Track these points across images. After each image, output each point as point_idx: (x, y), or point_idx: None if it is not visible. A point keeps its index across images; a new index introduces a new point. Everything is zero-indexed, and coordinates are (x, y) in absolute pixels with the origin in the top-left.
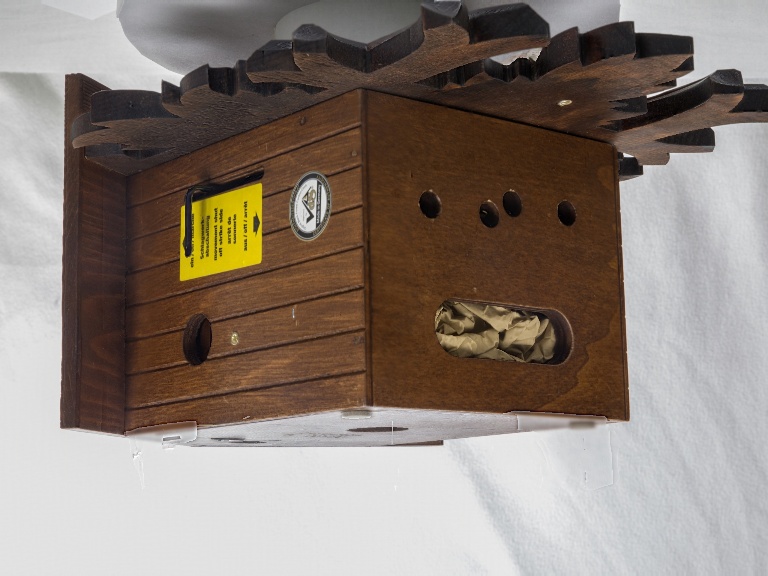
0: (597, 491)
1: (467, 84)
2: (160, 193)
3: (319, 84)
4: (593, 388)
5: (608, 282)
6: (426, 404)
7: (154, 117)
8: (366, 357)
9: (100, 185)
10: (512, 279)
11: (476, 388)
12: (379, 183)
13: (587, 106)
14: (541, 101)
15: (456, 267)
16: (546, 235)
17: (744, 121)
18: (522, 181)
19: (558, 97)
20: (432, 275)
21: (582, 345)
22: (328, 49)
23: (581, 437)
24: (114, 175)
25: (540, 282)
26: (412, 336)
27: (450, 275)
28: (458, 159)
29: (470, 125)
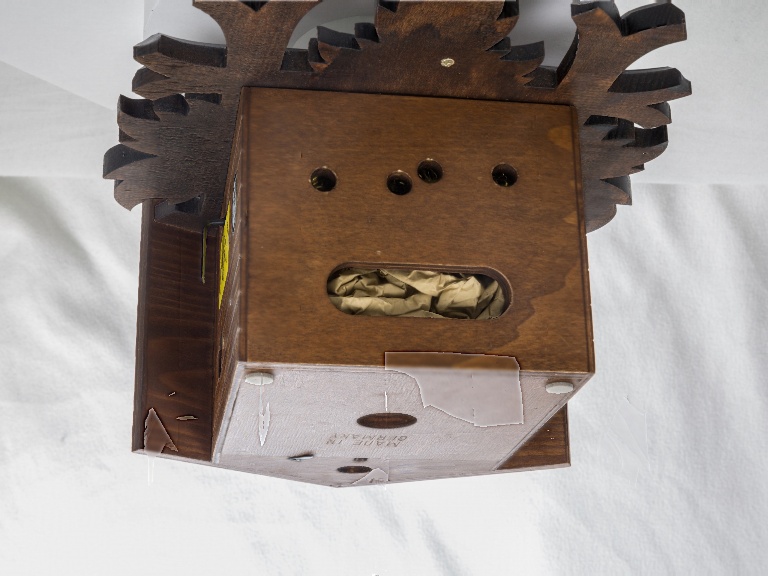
0: (650, 472)
1: (327, 60)
2: (219, 241)
3: (206, 90)
4: (541, 341)
5: (563, 237)
6: (313, 359)
7: (138, 160)
8: (240, 318)
9: (177, 244)
10: (428, 241)
11: (378, 343)
12: (262, 165)
13: (475, 62)
14: (424, 66)
15: (355, 233)
16: (475, 197)
17: (658, 44)
18: (443, 150)
19: (432, 57)
20: (324, 242)
21: (525, 299)
22: (163, 49)
23: (468, 375)
24: (198, 236)
25: (466, 242)
26: (297, 298)
27: (347, 241)
28: (360, 137)
29: (376, 105)
